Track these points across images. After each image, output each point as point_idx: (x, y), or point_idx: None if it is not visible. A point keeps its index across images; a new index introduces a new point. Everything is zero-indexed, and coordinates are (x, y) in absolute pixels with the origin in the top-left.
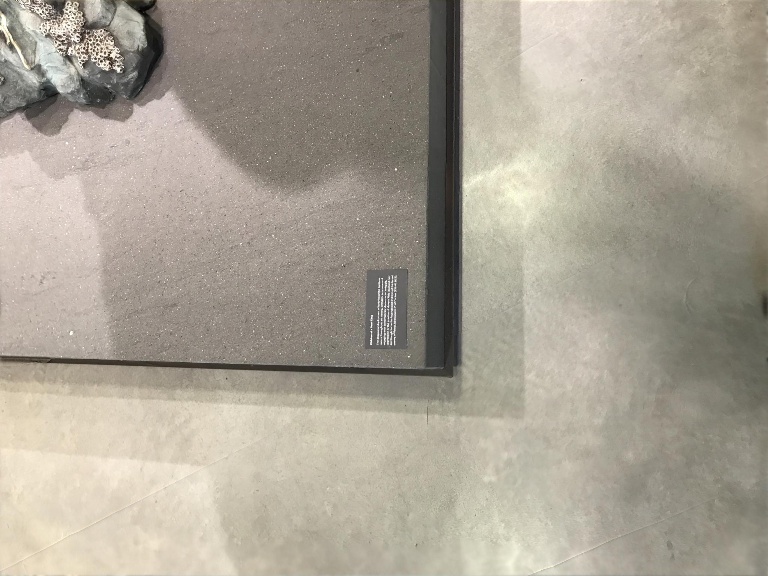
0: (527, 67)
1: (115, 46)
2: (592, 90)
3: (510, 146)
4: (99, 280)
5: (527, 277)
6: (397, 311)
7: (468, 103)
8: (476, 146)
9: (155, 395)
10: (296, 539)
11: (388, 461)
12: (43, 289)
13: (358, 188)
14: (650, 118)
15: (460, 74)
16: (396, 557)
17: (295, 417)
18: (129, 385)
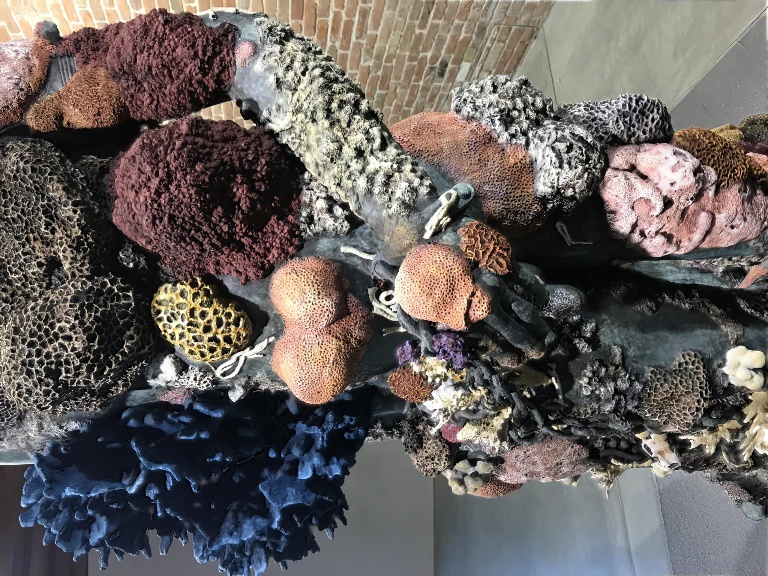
0: None
1: (738, 506)
2: None
3: None
4: (678, 477)
5: None
6: None
7: None
8: None
9: None
10: None
11: None
12: None
13: None
14: None
15: None
16: None
17: None
18: None
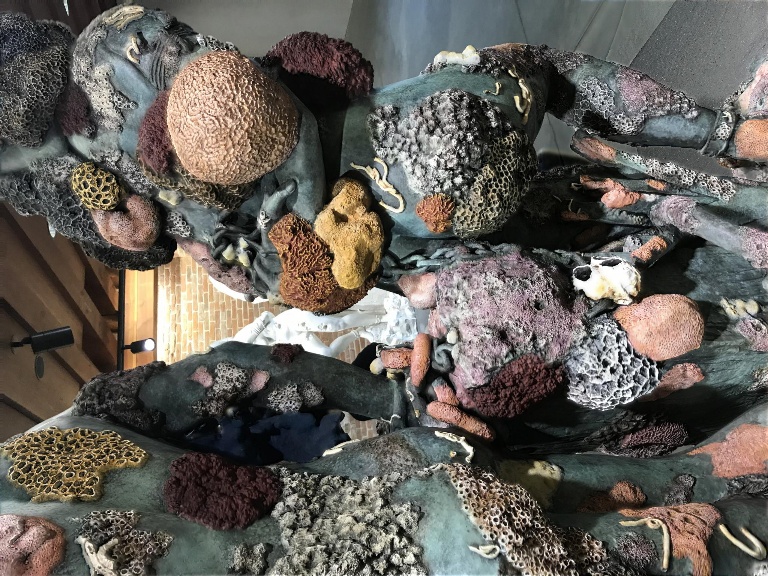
0: None
1: None
2: None
3: None
4: None
5: None
6: None
7: None
8: None
9: None
10: None
11: None
12: None
13: None
14: None
15: None
16: (639, 4)
17: None
18: None
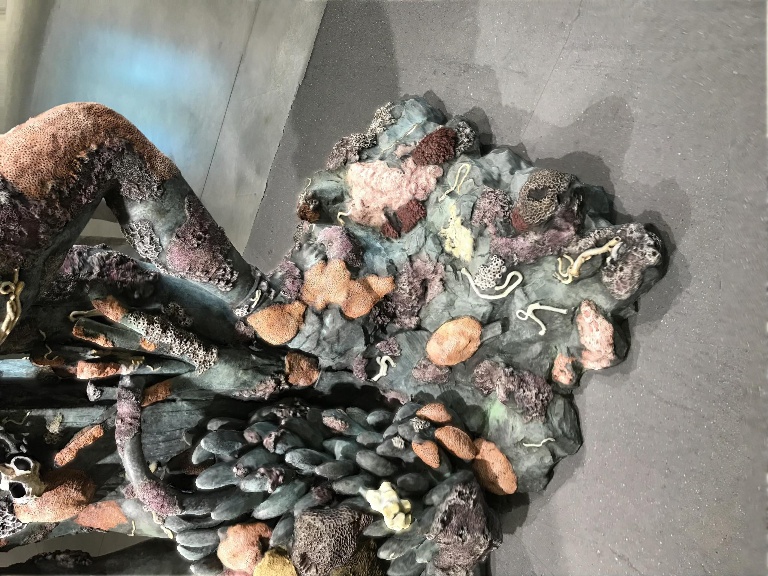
0: None
1: None
2: None
3: None
4: None
5: None
6: None
7: None
8: None
9: None
10: None
11: None
12: None
13: None
14: (312, 19)
15: None
16: None
17: None
18: None
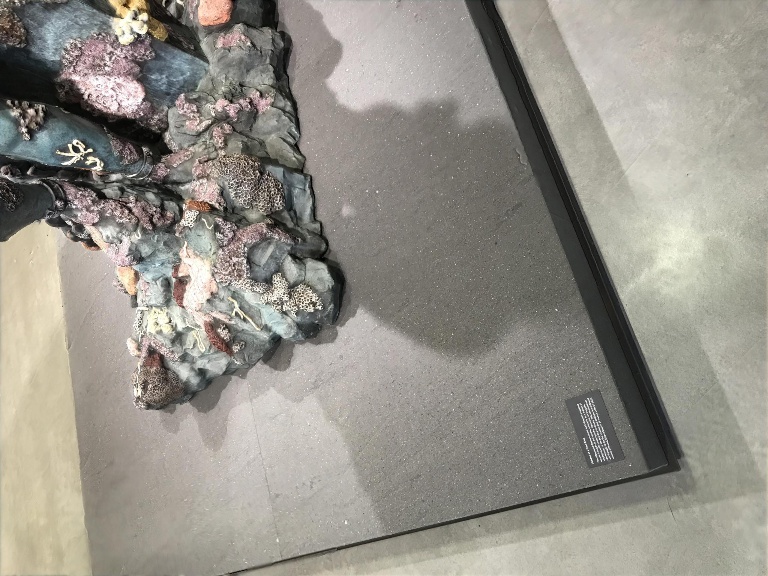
0: (635, 182)
1: (313, 293)
2: (701, 179)
3: (648, 251)
4: (354, 472)
5: (712, 358)
6: (604, 428)
7: (596, 228)
8: (618, 261)
9: (424, 557)
10: None
11: (652, 565)
12: (314, 492)
13: (531, 335)
14: (766, 183)
15: (580, 208)
16: None
17: (551, 545)
18: (401, 553)
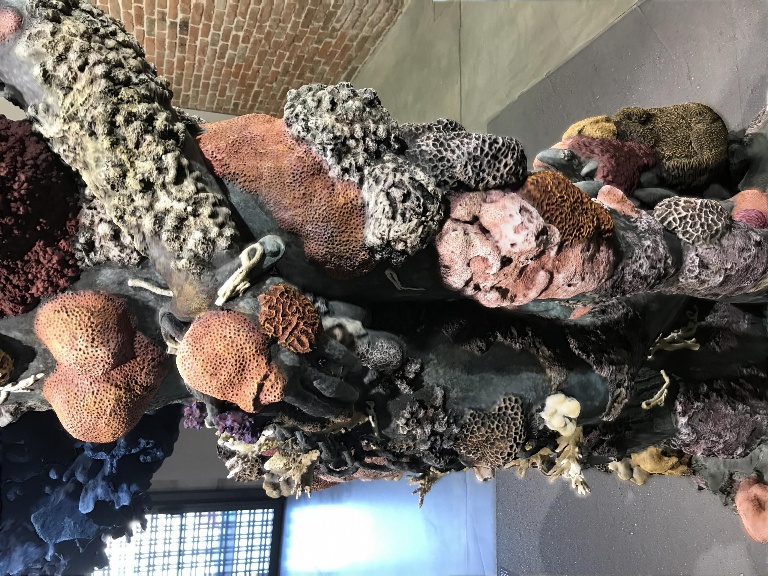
0: None
1: None
2: None
3: None
4: None
5: None
6: None
7: None
8: None
9: None
10: (490, 495)
11: None
12: None
13: None
14: None
15: None
16: (489, 542)
17: None
18: None
